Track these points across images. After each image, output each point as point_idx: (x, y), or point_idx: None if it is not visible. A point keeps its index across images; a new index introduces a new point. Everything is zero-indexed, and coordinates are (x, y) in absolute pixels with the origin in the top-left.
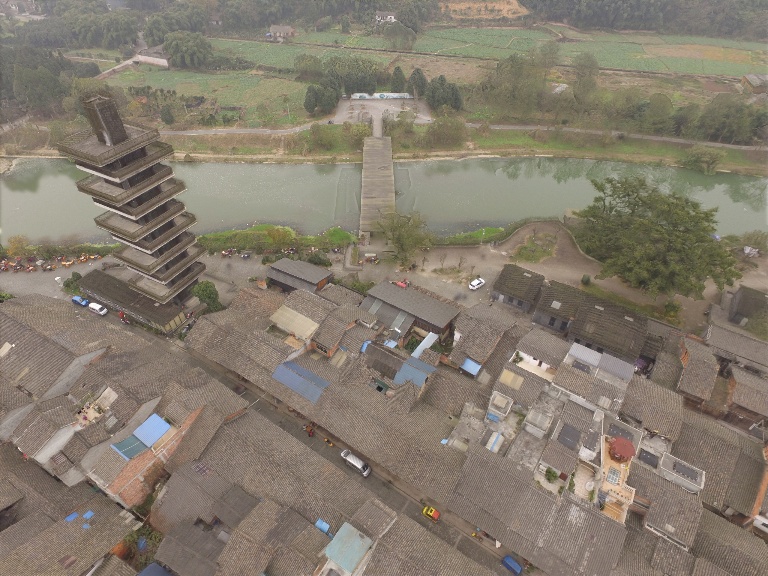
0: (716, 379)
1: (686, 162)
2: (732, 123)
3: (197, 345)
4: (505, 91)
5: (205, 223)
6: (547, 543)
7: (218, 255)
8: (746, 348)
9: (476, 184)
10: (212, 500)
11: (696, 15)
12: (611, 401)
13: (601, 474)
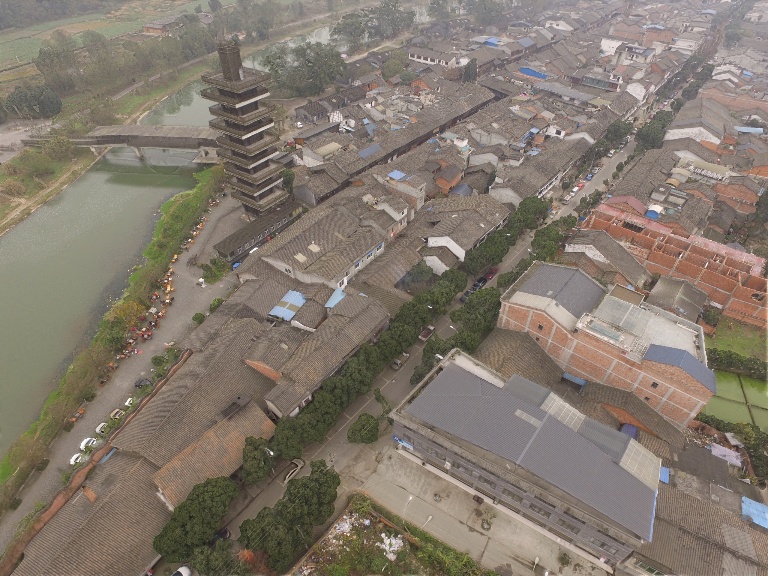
0: (385, 82)
1: (216, 67)
2: (206, 39)
3: (325, 191)
4: (95, 70)
5: (130, 239)
6: (444, 114)
7: (212, 208)
8: (370, 77)
9: (180, 123)
10: (426, 172)
11: (30, 6)
12: (397, 91)
13: (424, 99)
